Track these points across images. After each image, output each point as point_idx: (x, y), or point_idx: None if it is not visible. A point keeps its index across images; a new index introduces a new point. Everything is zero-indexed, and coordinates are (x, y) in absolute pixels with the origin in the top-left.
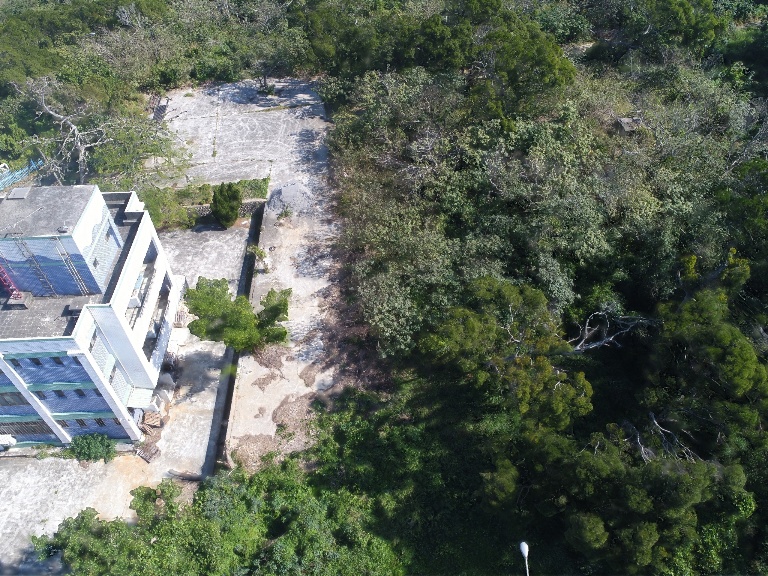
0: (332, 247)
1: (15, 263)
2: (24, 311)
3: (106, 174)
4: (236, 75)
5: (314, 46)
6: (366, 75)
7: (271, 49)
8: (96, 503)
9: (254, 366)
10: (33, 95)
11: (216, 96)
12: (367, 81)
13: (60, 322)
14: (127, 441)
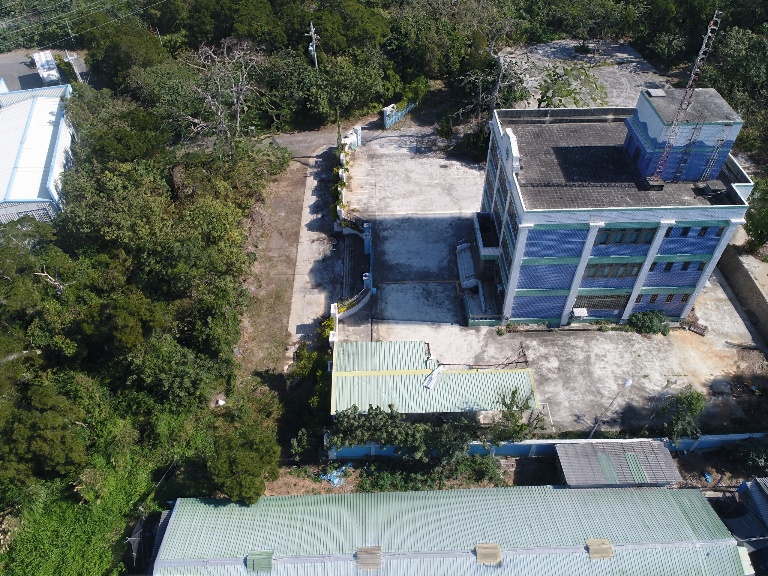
0: (753, 174)
1: (673, 148)
2: (660, 192)
3: (484, 116)
4: (546, 37)
5: (659, 6)
6: (733, 30)
7: (602, 10)
8: (681, 364)
9: (758, 262)
10: (418, 43)
11: (538, 54)
12: (734, 35)
13: (701, 200)
14: (673, 319)
